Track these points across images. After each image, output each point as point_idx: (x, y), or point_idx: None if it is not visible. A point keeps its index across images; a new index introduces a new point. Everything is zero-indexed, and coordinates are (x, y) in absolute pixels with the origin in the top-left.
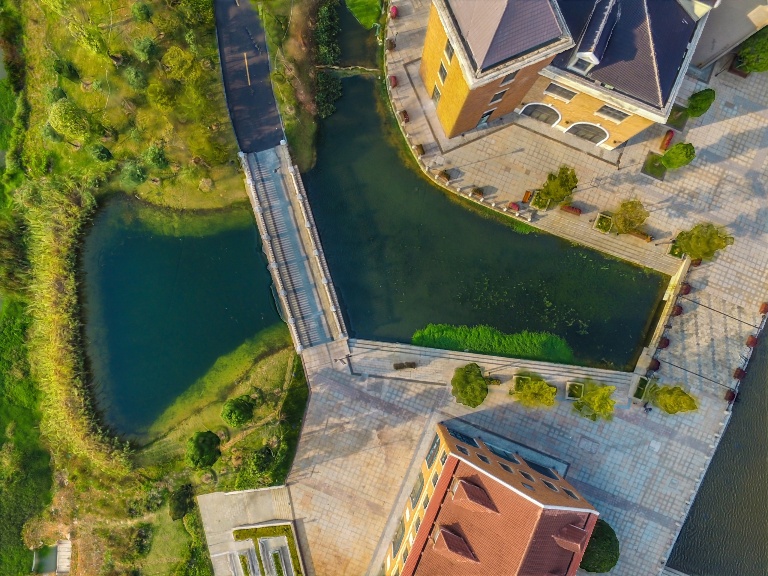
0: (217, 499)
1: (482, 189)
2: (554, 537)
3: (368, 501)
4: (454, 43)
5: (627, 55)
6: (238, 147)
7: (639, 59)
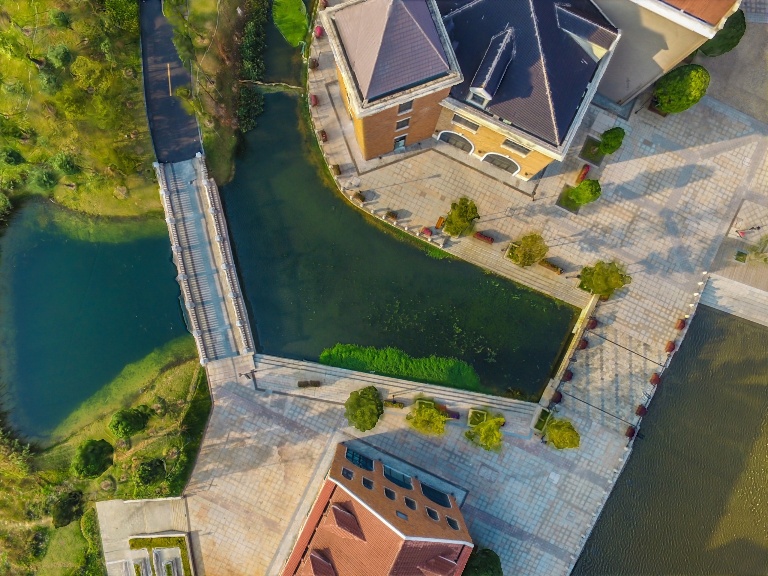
0: (116, 506)
1: (396, 212)
2: (420, 568)
3: (265, 517)
4: (343, 72)
5: (523, 92)
6: (155, 157)
7: (535, 96)
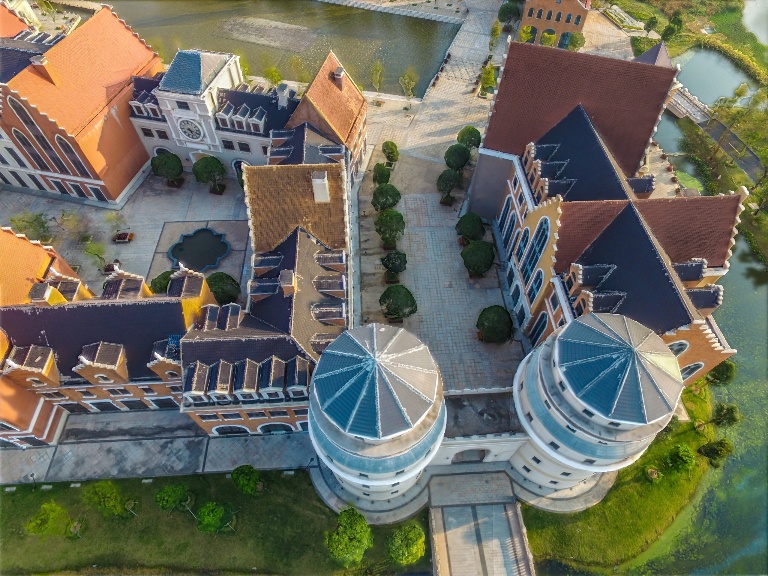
0: (654, 37)
1: None
2: None
3: None
4: None
5: None
6: None
7: None
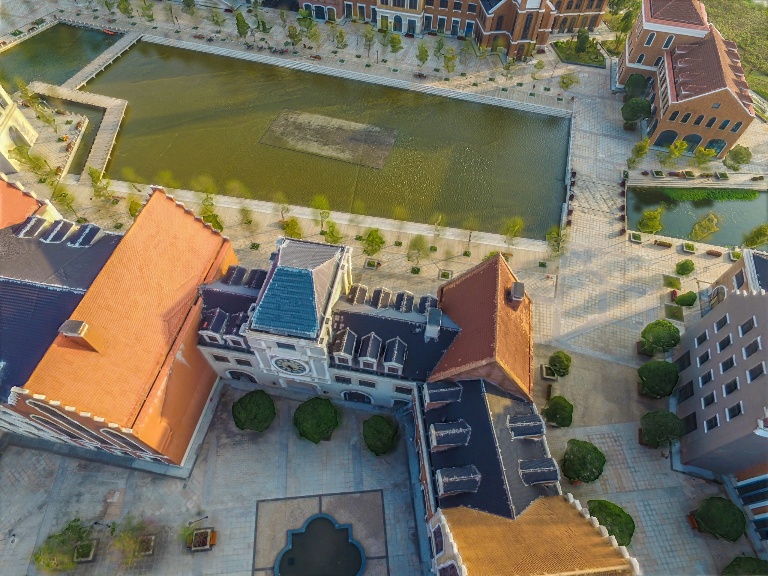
0: None
1: None
2: (704, 86)
3: None
4: None
5: None
6: None
7: None
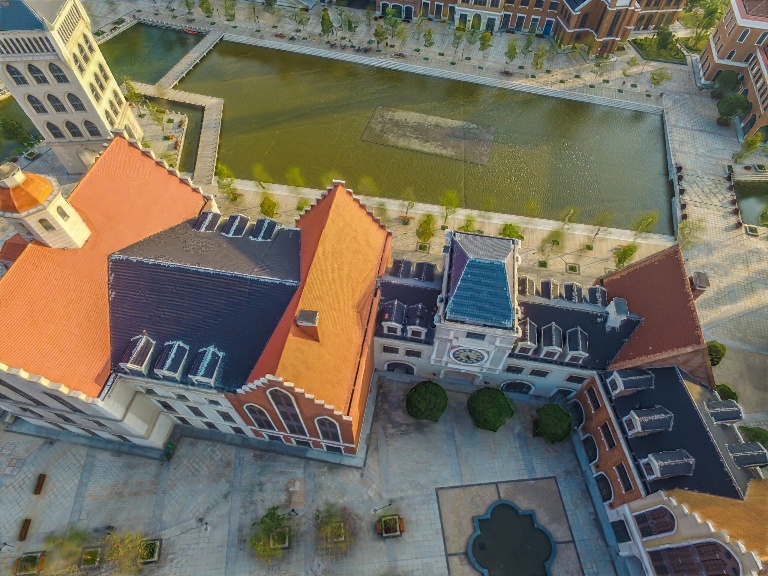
0: None
1: None
2: None
3: None
4: None
5: None
6: None
7: None
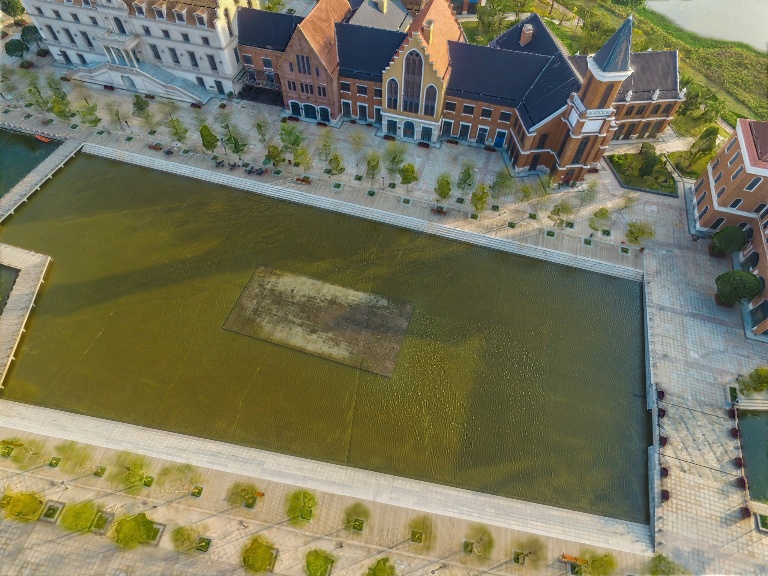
0: None
1: None
2: None
3: None
4: None
5: None
6: None
7: None
